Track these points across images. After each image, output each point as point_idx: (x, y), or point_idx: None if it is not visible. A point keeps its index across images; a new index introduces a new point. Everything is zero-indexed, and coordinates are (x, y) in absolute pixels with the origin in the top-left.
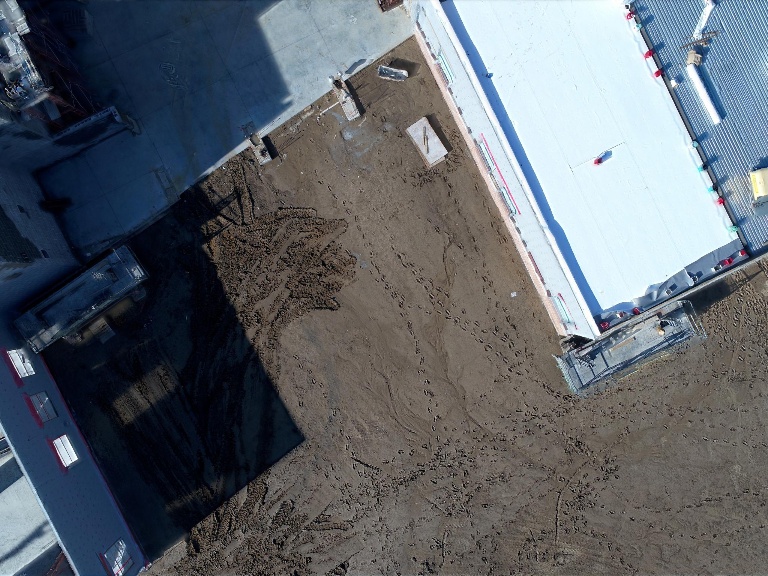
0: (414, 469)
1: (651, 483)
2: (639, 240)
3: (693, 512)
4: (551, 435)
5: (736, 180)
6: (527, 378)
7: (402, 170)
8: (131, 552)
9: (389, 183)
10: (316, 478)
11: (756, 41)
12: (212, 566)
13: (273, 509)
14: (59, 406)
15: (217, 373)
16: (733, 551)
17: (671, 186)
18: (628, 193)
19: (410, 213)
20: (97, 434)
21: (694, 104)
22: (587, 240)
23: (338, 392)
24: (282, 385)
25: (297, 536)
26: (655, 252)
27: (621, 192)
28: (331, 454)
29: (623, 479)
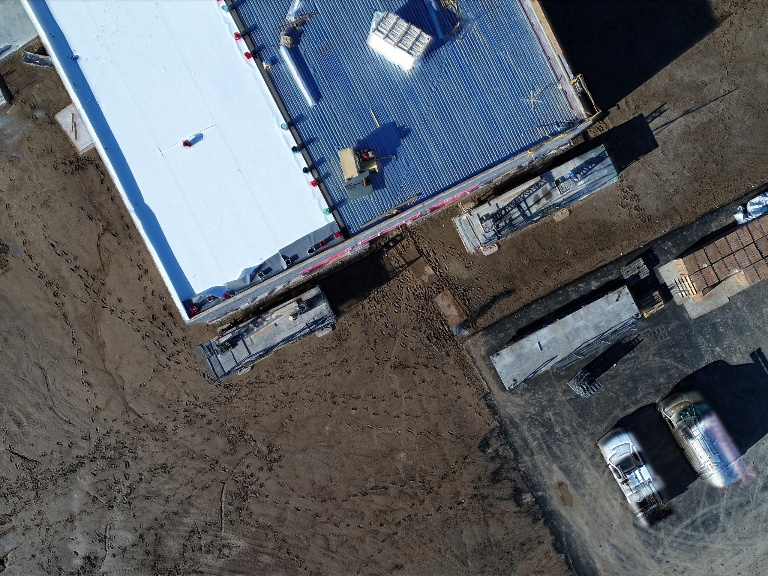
0: (74, 461)
1: (316, 472)
2: (232, 223)
3: (359, 501)
4: (213, 425)
5: (333, 162)
6: (186, 367)
7: (52, 157)
8: None
9: (39, 170)
10: None
11: (351, 23)
12: None
13: None
14: None
15: None
16: (400, 540)
17: (264, 169)
18: (220, 176)
19: (62, 201)
20: None
21: (289, 86)
22: (178, 224)
23: None
24: None
25: None
26: (249, 235)
27: (213, 175)
28: None
29: (288, 468)
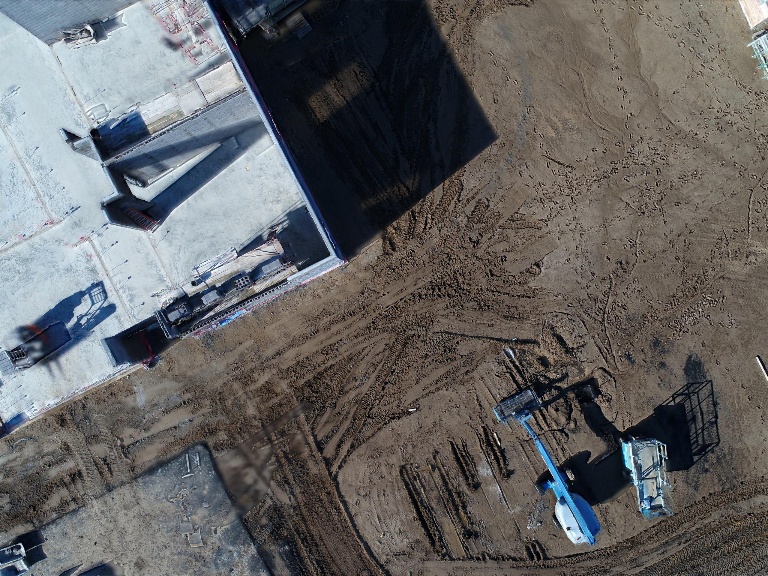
0: (607, 167)
1: None
2: None
3: None
4: (743, 132)
5: None
6: (720, 74)
7: None
8: (333, 242)
9: None
10: (510, 176)
11: None
12: (408, 265)
13: (469, 207)
14: (260, 97)
15: (413, 69)
16: None
17: None
18: None
19: None
20: (293, 132)
21: None
22: None
23: (532, 90)
24: (477, 82)
25: (492, 234)
26: None
27: None
28: (525, 153)
29: None
